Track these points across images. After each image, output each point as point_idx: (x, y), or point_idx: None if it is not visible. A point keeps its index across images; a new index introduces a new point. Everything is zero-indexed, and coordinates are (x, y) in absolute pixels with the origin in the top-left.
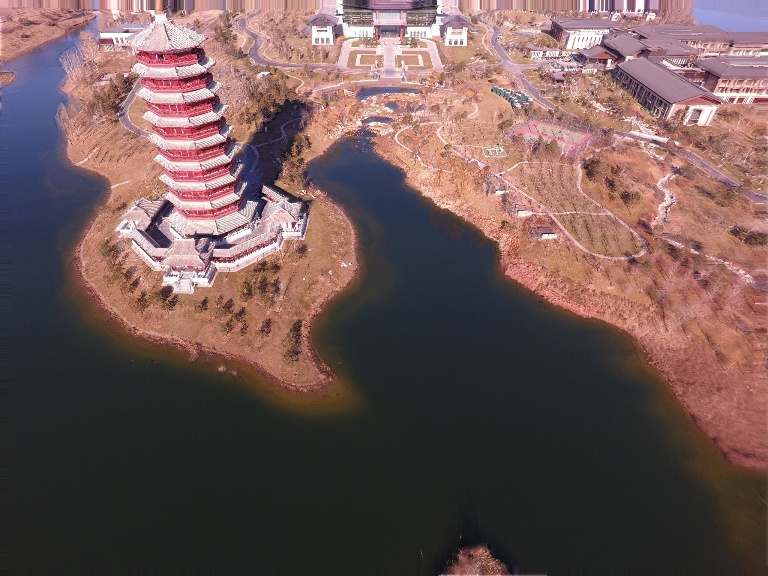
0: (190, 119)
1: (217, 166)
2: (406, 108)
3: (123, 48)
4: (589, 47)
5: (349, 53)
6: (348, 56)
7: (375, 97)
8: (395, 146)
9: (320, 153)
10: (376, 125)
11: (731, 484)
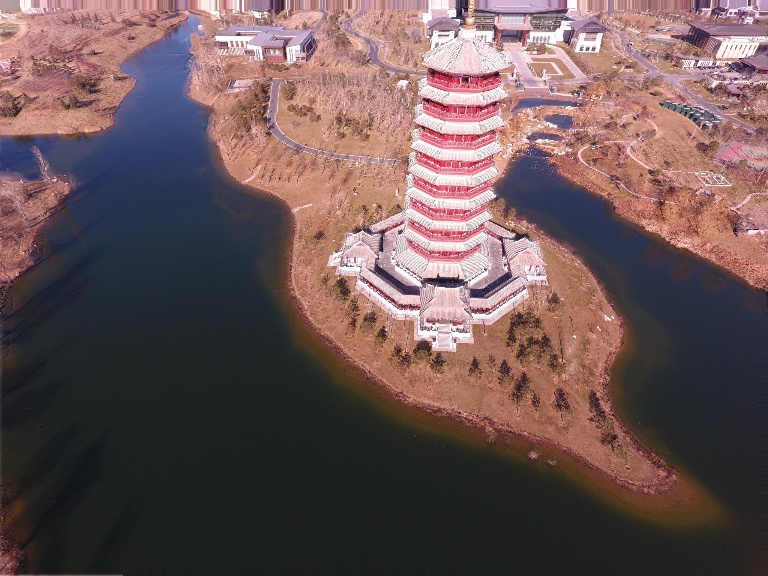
0: (475, 151)
1: (482, 203)
2: (569, 123)
3: (246, 53)
4: (741, 56)
5: None
6: None
7: (530, 110)
8: (585, 169)
9: (501, 175)
10: (545, 142)
11: None
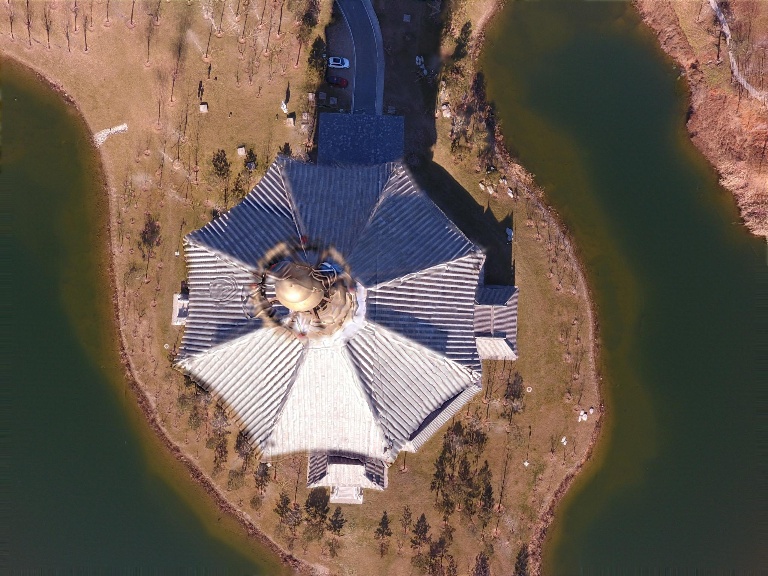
0: None
1: None
2: None
3: None
4: None
5: None
6: None
7: None
8: None
9: None
10: None
11: None
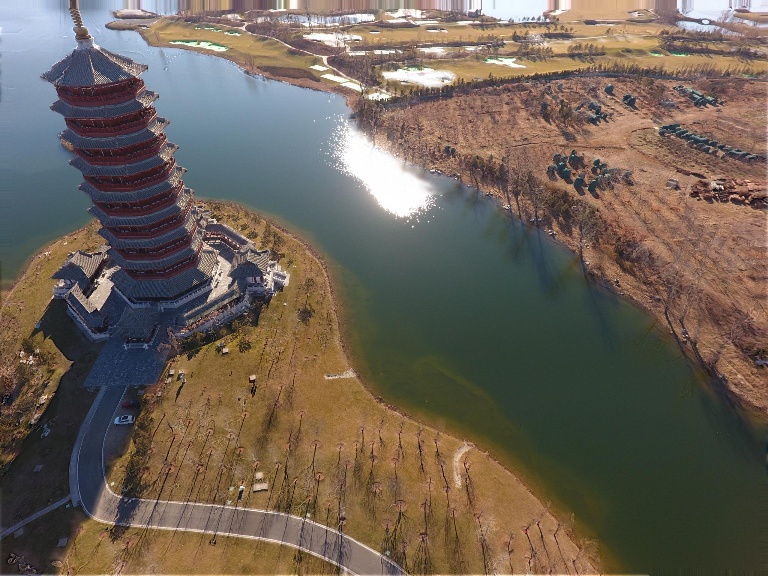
0: None
1: None
2: None
3: None
4: None
5: None
6: None
7: None
8: None
9: None
10: None
11: None
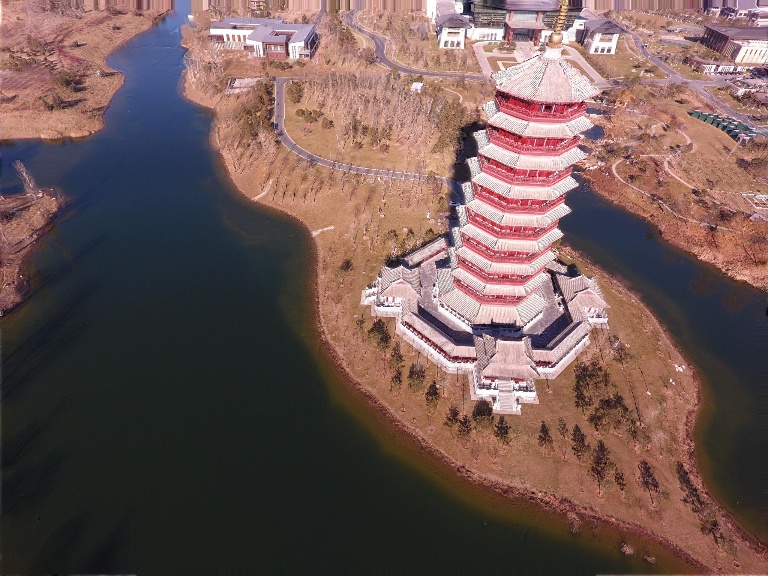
0: (550, 188)
1: None
2: (596, 133)
3: (245, 48)
4: (760, 61)
5: (487, 59)
6: (488, 63)
7: None
8: (622, 186)
9: None
10: None
11: None
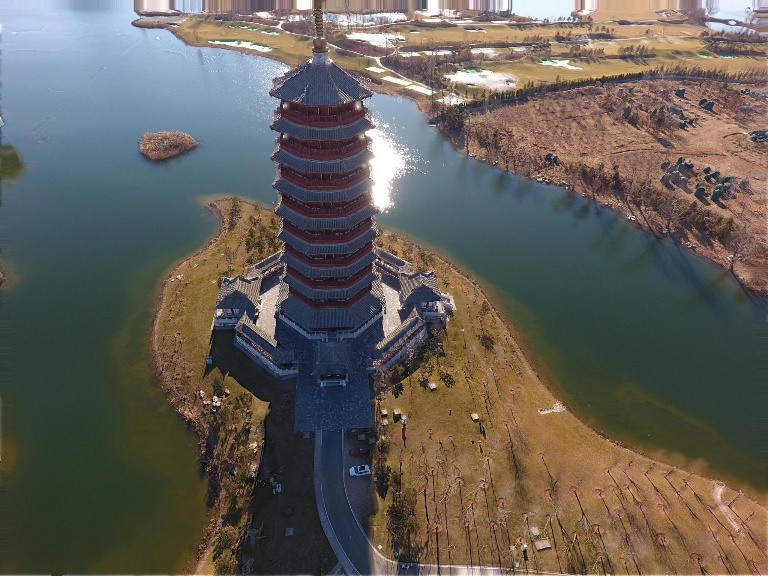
0: None
1: None
2: None
3: None
4: None
5: None
6: None
7: None
8: None
9: None
10: None
11: (8, 178)
